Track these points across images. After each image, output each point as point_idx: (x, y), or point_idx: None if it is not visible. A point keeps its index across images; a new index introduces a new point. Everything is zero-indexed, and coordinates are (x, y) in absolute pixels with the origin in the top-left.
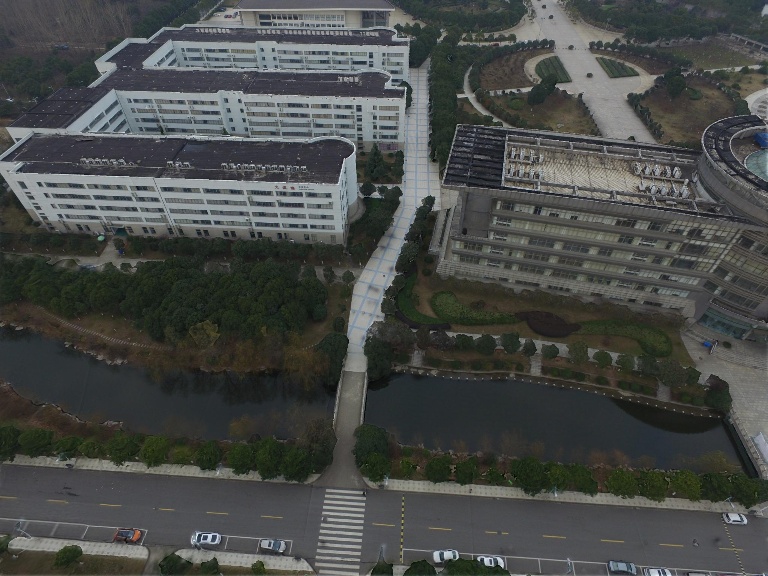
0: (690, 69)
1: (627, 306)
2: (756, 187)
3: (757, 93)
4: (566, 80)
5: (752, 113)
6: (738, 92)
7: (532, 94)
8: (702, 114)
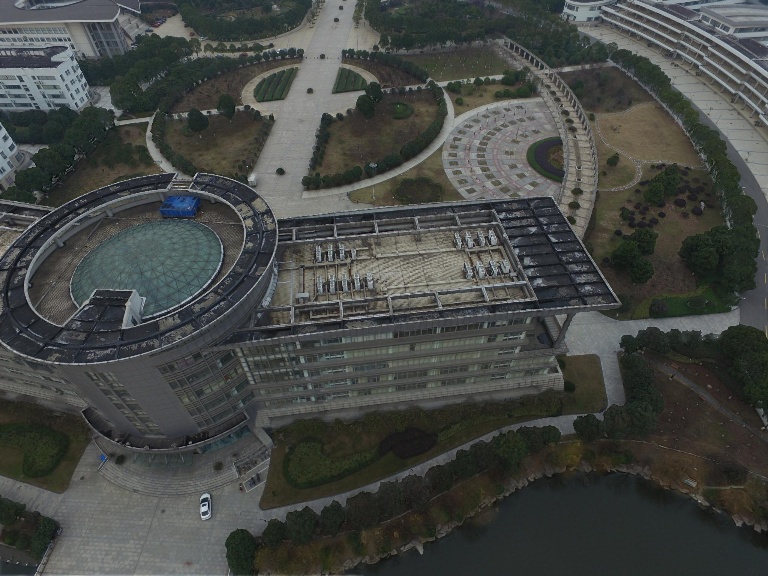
0: (392, 85)
1: (39, 407)
2: (2, 289)
3: (478, 109)
4: (277, 98)
5: (450, 134)
6: (445, 110)
7: (188, 120)
8: (391, 137)
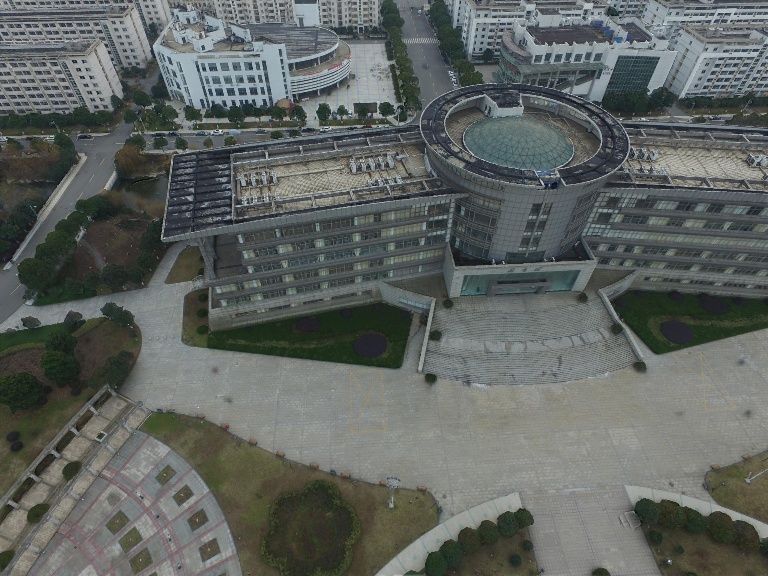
0: None
1: None
2: None
3: None
4: None
5: None
6: None
7: None
8: None
